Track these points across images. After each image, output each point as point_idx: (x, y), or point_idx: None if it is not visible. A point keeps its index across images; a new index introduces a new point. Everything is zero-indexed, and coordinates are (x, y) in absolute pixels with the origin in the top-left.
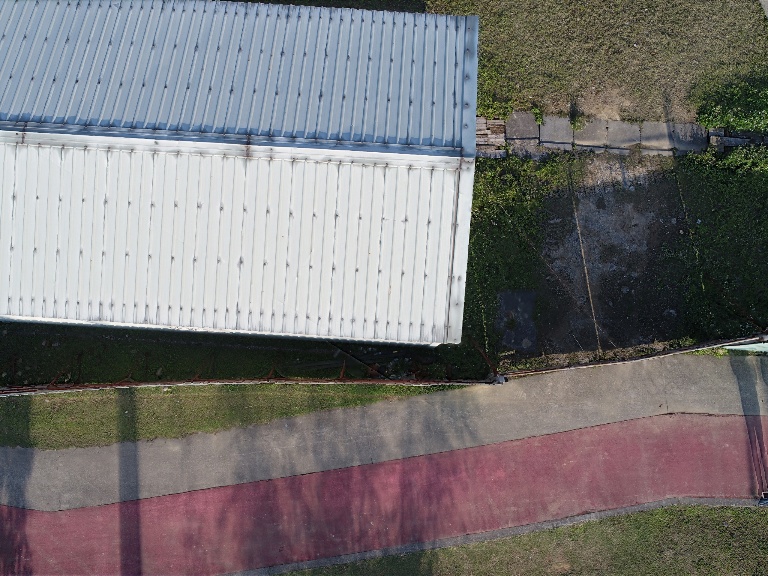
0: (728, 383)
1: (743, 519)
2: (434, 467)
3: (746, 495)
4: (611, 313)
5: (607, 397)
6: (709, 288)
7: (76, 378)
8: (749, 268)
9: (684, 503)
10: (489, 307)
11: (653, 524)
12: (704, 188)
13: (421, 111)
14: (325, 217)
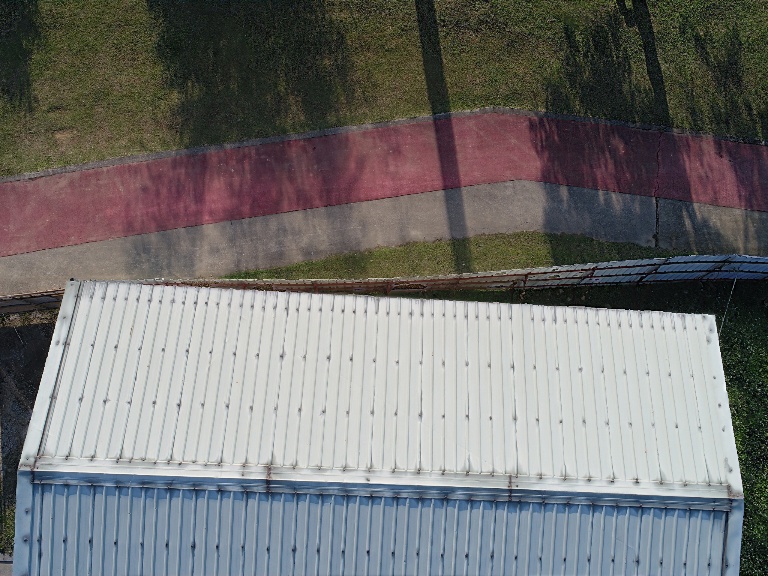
0: None
1: None
2: (173, 217)
3: None
4: None
5: None
6: None
7: (515, 295)
8: None
9: None
10: None
11: None
12: None
13: (78, 530)
14: (191, 403)
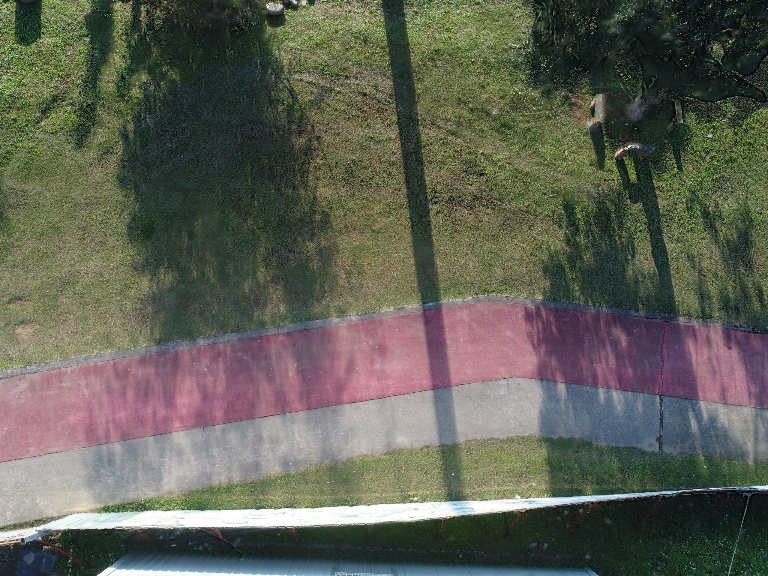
0: None
1: None
2: (141, 424)
3: None
4: None
5: None
6: None
7: None
8: None
9: None
10: None
11: None
12: None
13: None
14: None
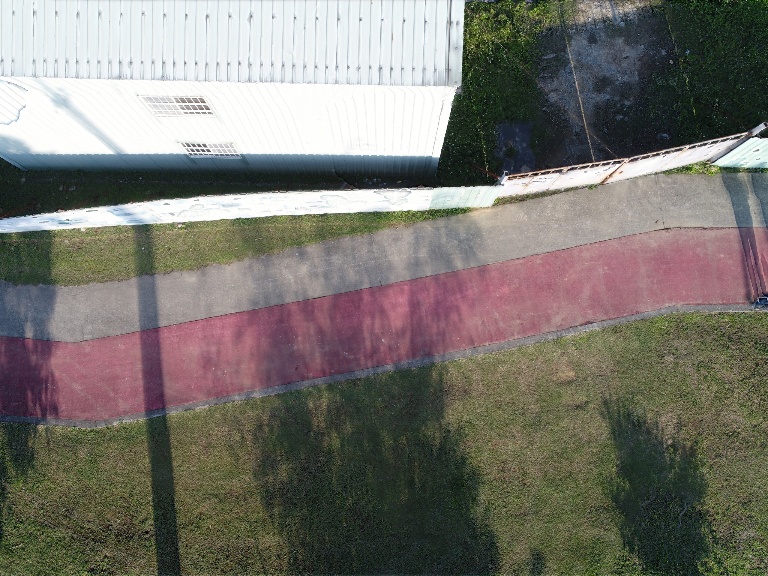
0: (721, 198)
1: (740, 324)
2: (441, 286)
3: (742, 301)
4: (606, 139)
5: (605, 216)
6: (700, 112)
7: None
8: (738, 92)
9: (683, 311)
10: (488, 134)
11: (653, 332)
12: (692, 21)
13: None
14: None
